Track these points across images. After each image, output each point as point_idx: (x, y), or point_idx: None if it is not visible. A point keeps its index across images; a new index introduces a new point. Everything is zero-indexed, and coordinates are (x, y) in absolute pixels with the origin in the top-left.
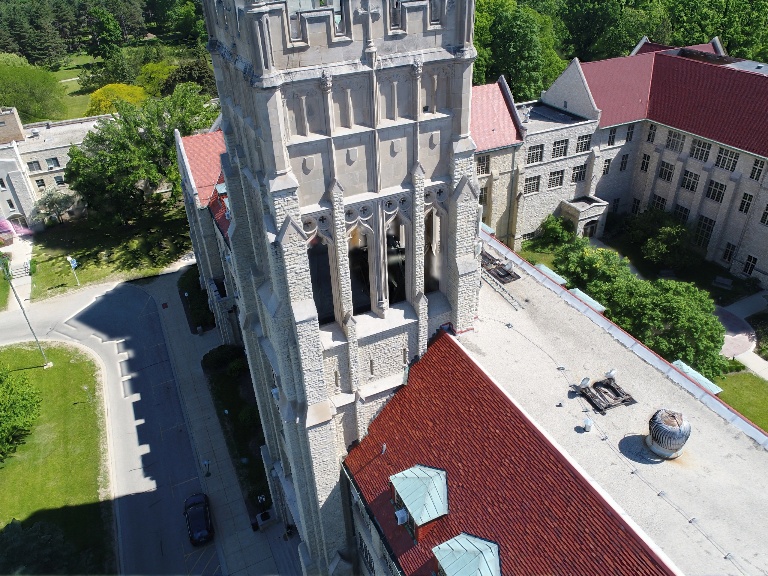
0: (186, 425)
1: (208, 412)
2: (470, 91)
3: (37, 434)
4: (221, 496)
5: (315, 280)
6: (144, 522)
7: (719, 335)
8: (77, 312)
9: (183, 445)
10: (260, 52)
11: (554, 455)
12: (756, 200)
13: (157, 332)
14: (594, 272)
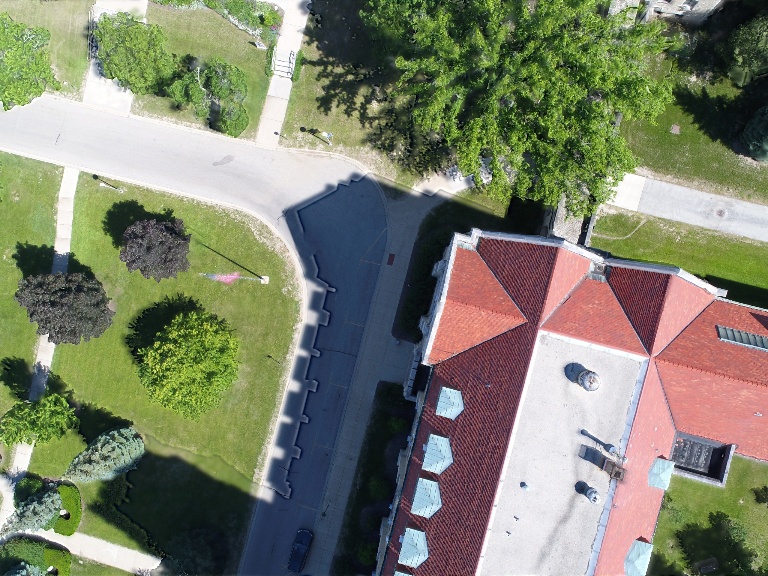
0: (333, 452)
1: (353, 452)
2: None
3: None
4: (322, 540)
5: None
6: (271, 520)
7: None
8: (313, 200)
9: (322, 472)
10: None
11: None
12: None
13: (365, 303)
14: None
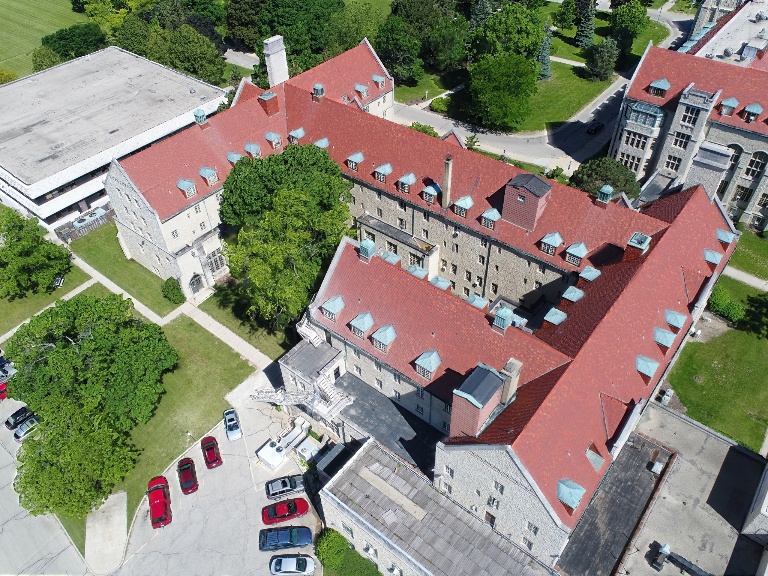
0: None
1: None
2: None
3: (638, 39)
4: None
5: None
6: None
7: None
8: (679, 20)
9: None
10: None
11: None
12: None
13: None
14: None
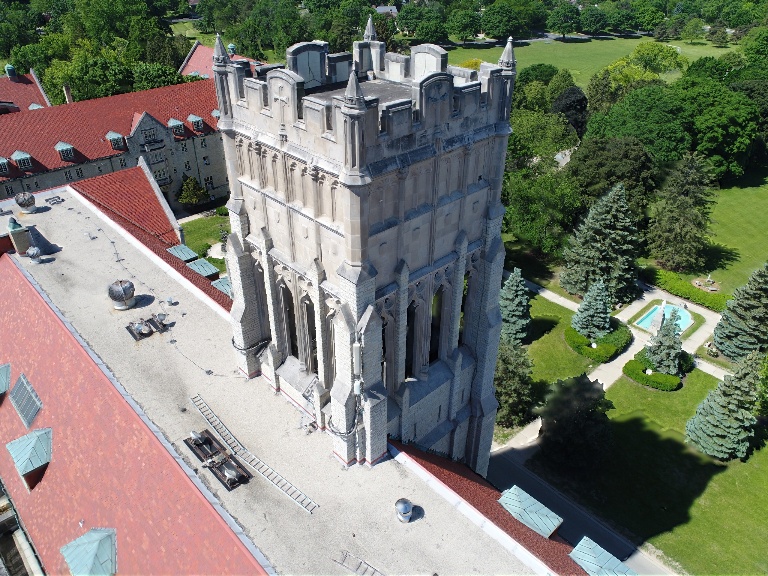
0: None
1: None
2: None
3: None
4: None
5: None
6: None
7: None
8: None
9: None
10: None
11: None
12: None
13: None
14: None
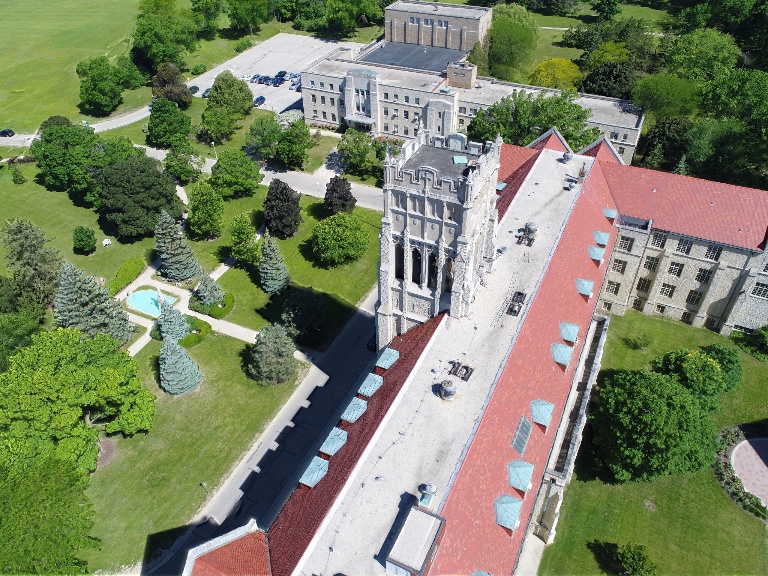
0: None
1: None
2: (467, 219)
3: (359, 262)
4: None
5: (399, 259)
6: (361, 326)
7: (675, 446)
8: None
9: None
10: (385, 177)
11: None
12: None
13: None
14: (681, 368)
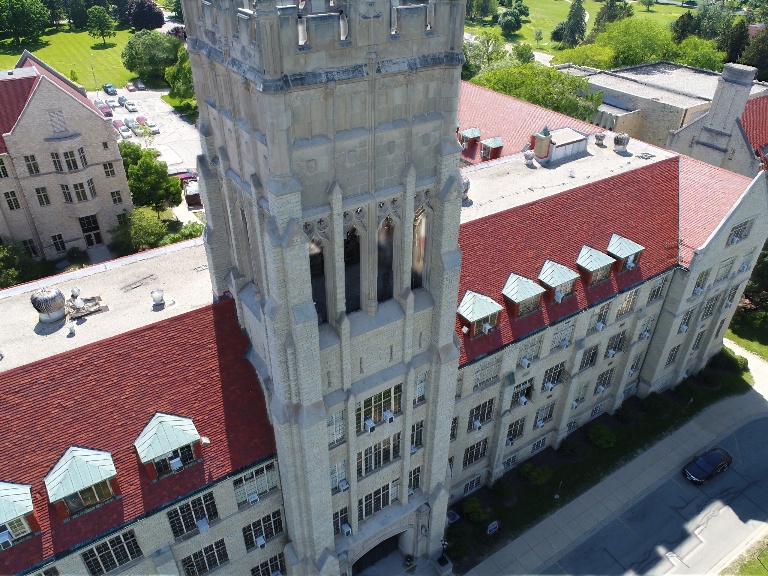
0: None
1: None
2: None
3: None
4: None
5: None
6: None
7: None
8: None
9: None
10: None
11: (482, 221)
12: (23, 191)
13: None
14: None
